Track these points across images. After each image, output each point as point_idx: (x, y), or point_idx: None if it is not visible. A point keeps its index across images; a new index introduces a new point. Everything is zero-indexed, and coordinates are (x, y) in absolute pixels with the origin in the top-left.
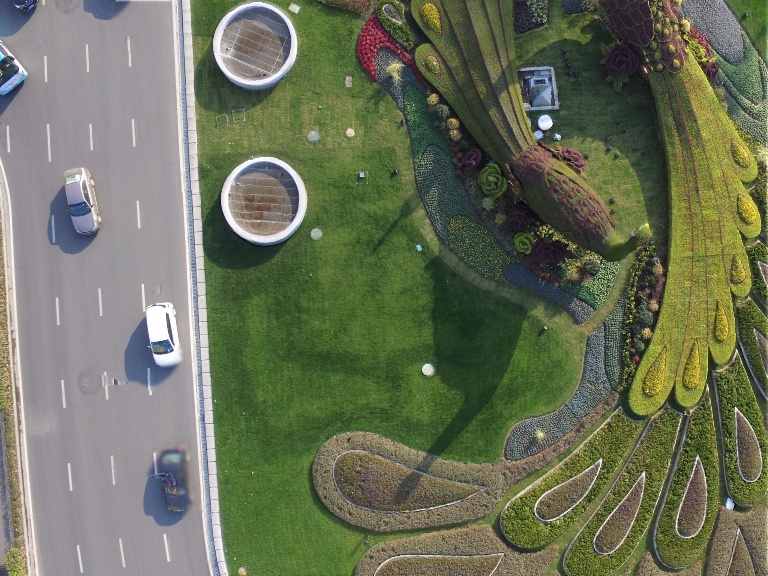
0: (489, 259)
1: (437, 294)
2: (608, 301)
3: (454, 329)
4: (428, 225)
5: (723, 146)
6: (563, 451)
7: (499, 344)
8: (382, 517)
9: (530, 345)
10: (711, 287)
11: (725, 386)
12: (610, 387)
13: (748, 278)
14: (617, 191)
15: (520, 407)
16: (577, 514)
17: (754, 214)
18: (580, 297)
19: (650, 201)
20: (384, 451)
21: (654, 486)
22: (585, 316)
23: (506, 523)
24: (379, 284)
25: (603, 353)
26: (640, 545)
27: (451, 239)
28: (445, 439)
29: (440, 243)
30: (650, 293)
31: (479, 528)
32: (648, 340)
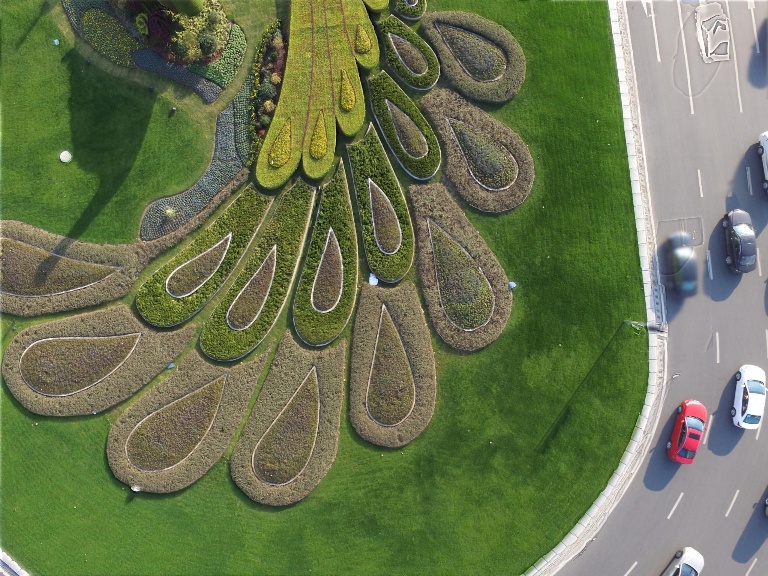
0: (119, 46)
1: (73, 84)
2: (236, 80)
3: (89, 116)
4: (65, 21)
5: None
6: (194, 228)
7: (131, 127)
8: (25, 302)
9: (161, 126)
10: (334, 57)
11: (357, 157)
12: (241, 164)
13: (375, 48)
14: None
15: (153, 188)
16: (209, 290)
17: None
18: (208, 77)
19: None
20: (24, 236)
21: (286, 259)
22: (214, 96)
23: (139, 301)
24: (21, 79)
25: (233, 131)
26: (281, 323)
27: (85, 31)
28: (83, 223)
29: (76, 36)
30: (273, 67)
31: (116, 308)
32: (272, 113)
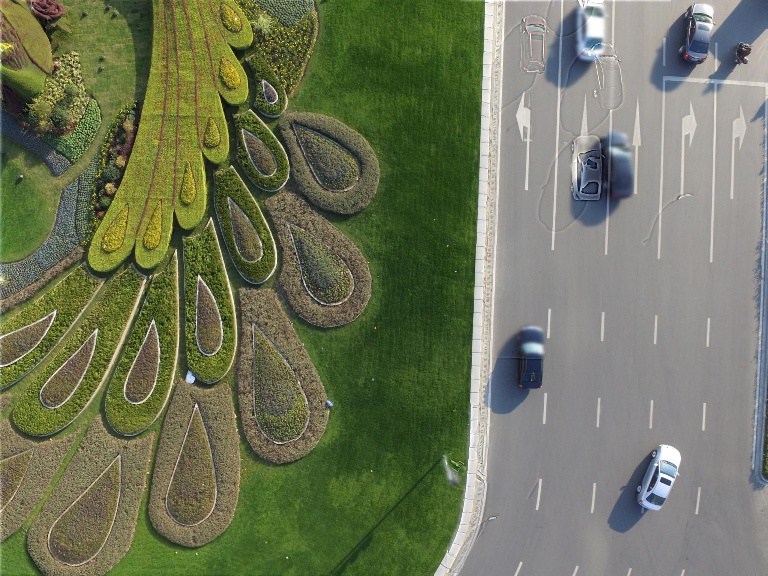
0: None
1: None
2: (86, 156)
3: None
4: None
5: (210, 8)
6: (23, 299)
7: None
8: None
9: (7, 192)
10: (181, 148)
11: (190, 252)
12: (78, 242)
13: (224, 144)
14: (110, 49)
15: None
16: (27, 363)
17: (236, 78)
18: (58, 149)
19: (141, 61)
20: None
21: (105, 345)
22: (62, 169)
23: None
24: None
25: (75, 207)
26: (94, 407)
27: None
28: None
29: None
30: None
31: None
32: (113, 196)
